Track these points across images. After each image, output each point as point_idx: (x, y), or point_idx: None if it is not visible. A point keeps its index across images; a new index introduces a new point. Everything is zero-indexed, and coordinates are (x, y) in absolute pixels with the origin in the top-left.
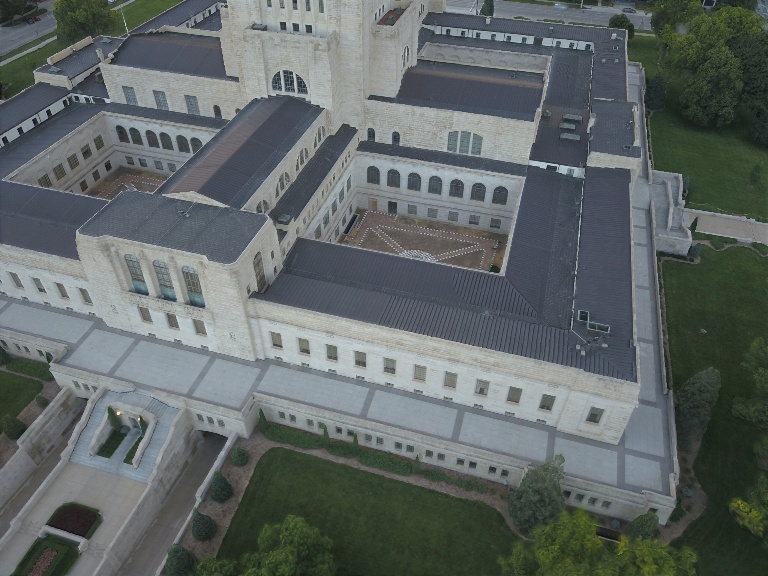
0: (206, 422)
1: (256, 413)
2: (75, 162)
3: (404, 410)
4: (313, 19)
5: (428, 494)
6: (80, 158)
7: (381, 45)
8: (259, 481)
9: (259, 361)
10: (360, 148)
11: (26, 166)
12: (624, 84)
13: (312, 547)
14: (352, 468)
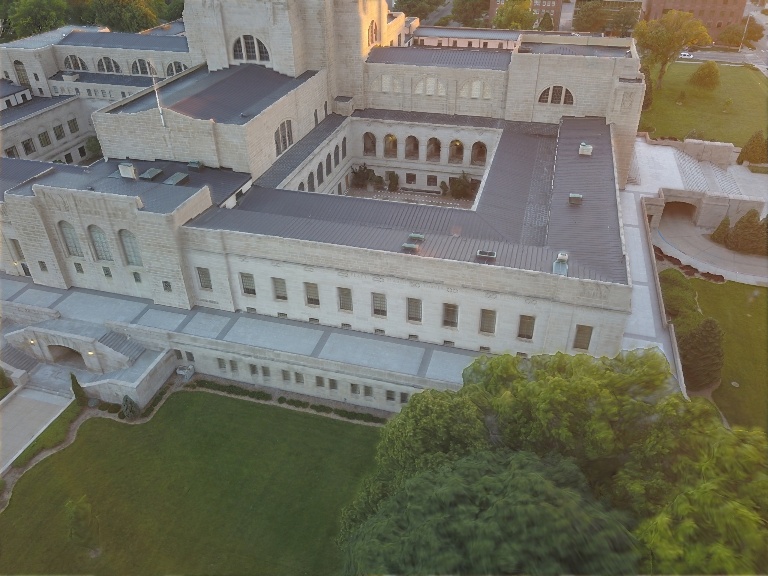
0: None
1: None
2: None
3: None
4: None
5: None
6: None
7: None
8: None
9: None
10: None
11: None
12: None
13: None
14: None
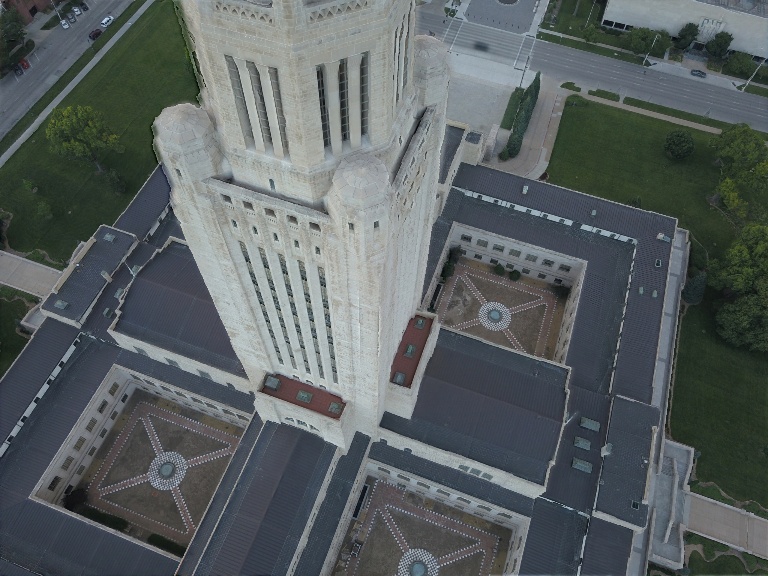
0: None
1: None
2: (93, 422)
3: None
4: (327, 386)
5: None
6: (97, 417)
7: (397, 395)
8: None
9: None
10: (372, 452)
11: (49, 471)
12: (655, 347)
13: None
14: None
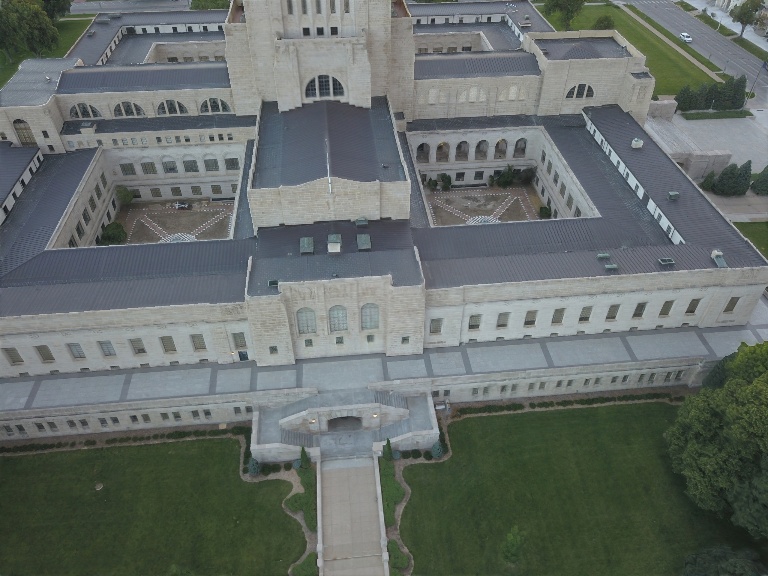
0: None
1: None
2: None
3: None
4: None
5: None
6: None
7: None
8: None
9: None
10: None
11: (174, 43)
12: None
13: None
14: None
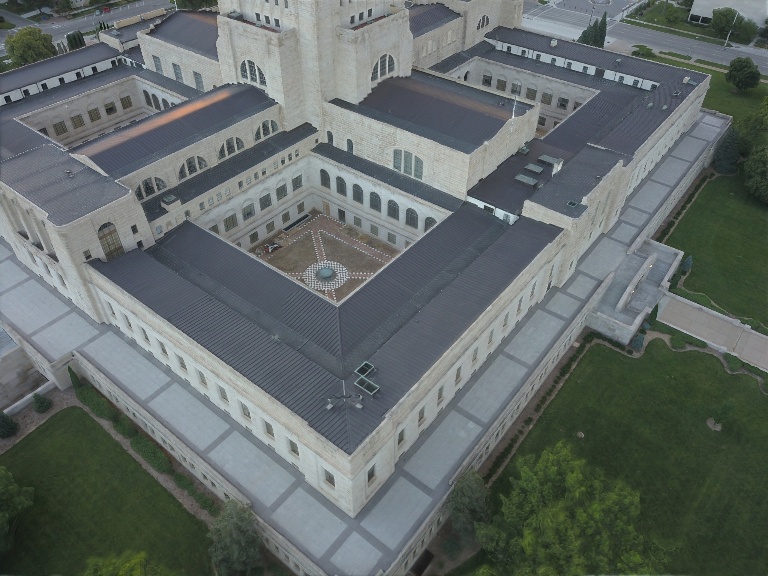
0: (37, 365)
1: (77, 370)
2: (97, 116)
3: (183, 409)
4: (279, 14)
5: (165, 497)
6: (102, 113)
7: (344, 49)
8: (43, 431)
9: (103, 324)
10: (317, 149)
11: (40, 111)
12: (650, 135)
13: (0, 501)
14: (121, 448)
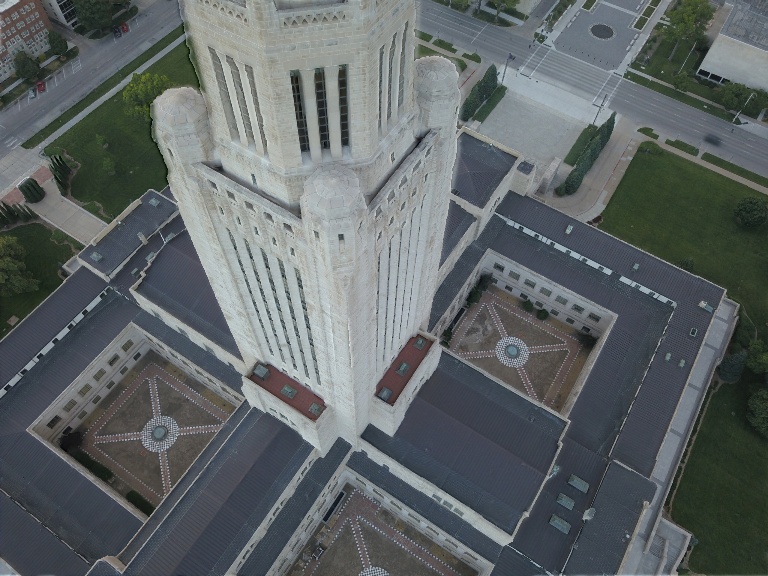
0: None
1: None
2: (102, 373)
3: None
4: (311, 386)
5: None
6: (107, 369)
7: (380, 410)
8: None
9: None
10: (351, 461)
11: (50, 409)
12: (669, 418)
13: None
14: None
